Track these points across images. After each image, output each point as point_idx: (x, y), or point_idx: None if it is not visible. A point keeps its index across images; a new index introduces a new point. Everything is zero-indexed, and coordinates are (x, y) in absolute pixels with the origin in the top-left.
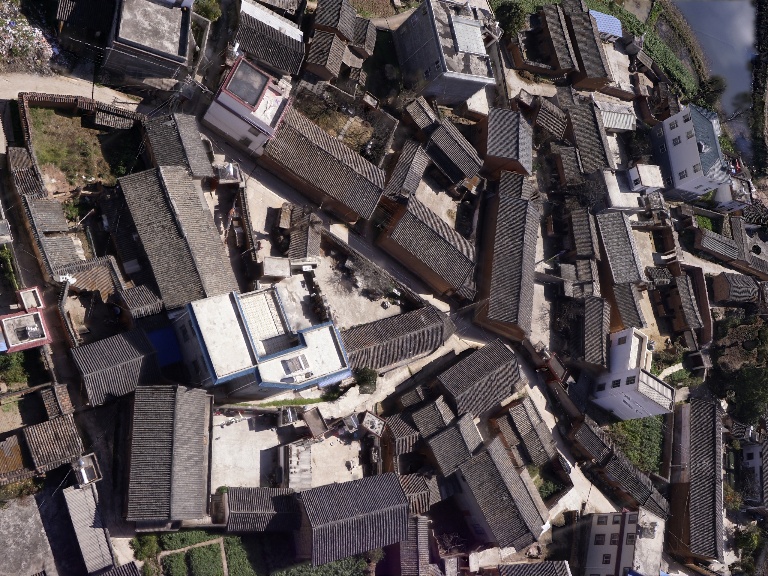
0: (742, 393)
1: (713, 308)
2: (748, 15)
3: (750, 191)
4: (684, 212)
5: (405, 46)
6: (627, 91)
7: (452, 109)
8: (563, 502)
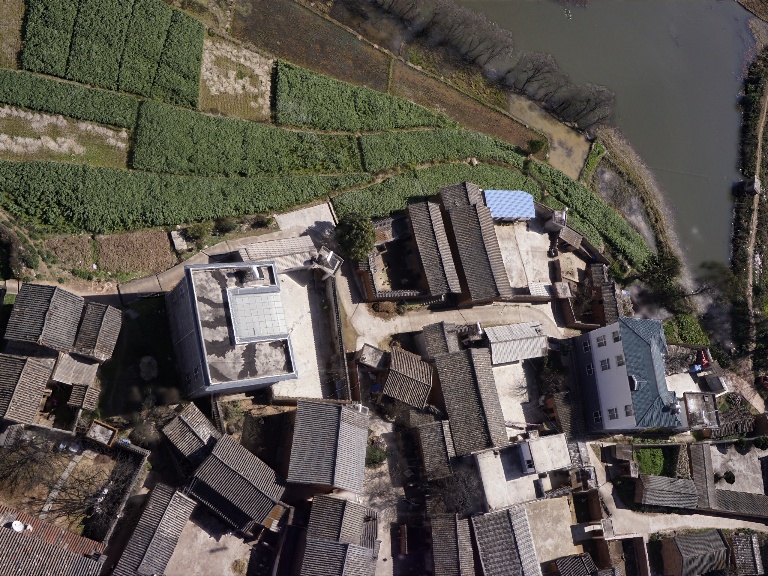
0: None
1: None
2: (729, 128)
3: (716, 408)
4: (620, 455)
5: (177, 321)
6: (539, 296)
7: (253, 397)
8: None
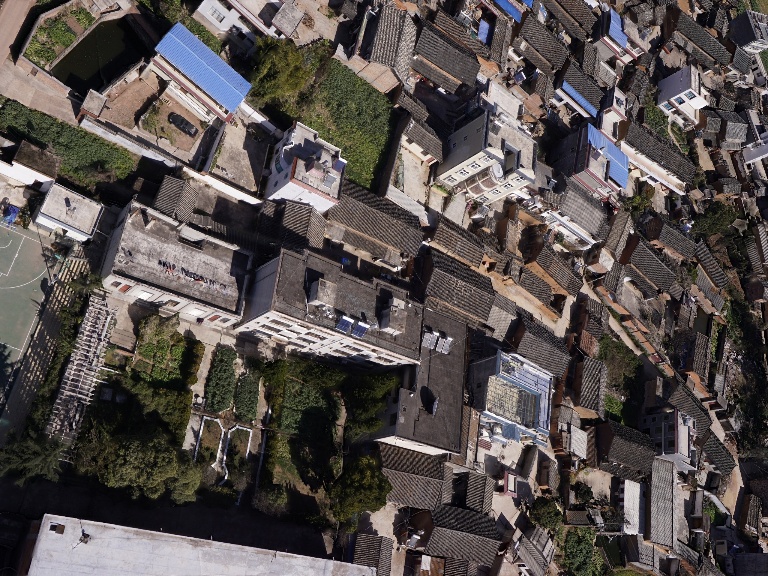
0: (709, 206)
1: None
2: None
3: None
4: (765, 221)
5: None
6: None
7: None
8: None
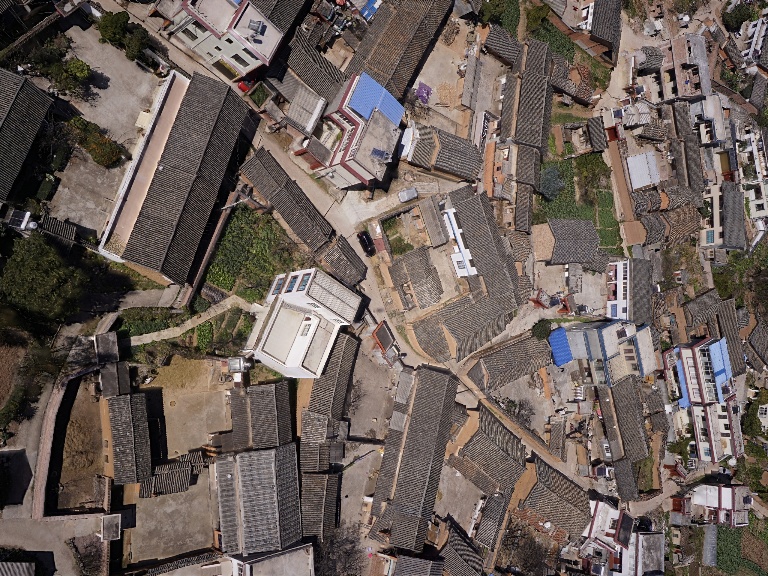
0: None
1: (1, 448)
2: None
3: None
4: None
5: None
6: None
7: None
8: (368, 209)
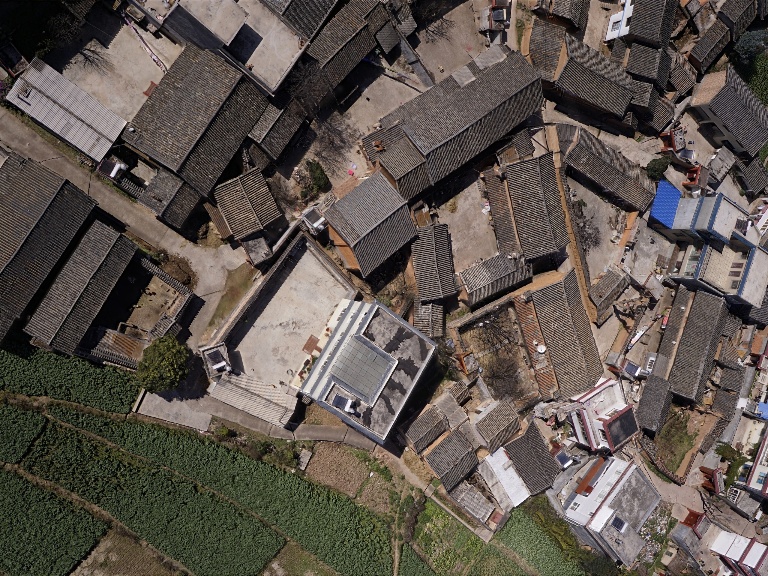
0: None
1: None
2: None
3: None
4: None
5: None
6: None
7: None
8: None
